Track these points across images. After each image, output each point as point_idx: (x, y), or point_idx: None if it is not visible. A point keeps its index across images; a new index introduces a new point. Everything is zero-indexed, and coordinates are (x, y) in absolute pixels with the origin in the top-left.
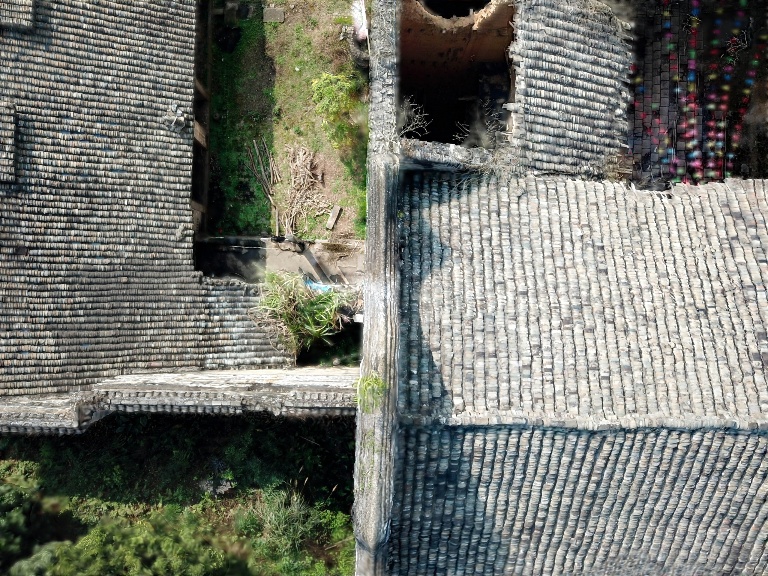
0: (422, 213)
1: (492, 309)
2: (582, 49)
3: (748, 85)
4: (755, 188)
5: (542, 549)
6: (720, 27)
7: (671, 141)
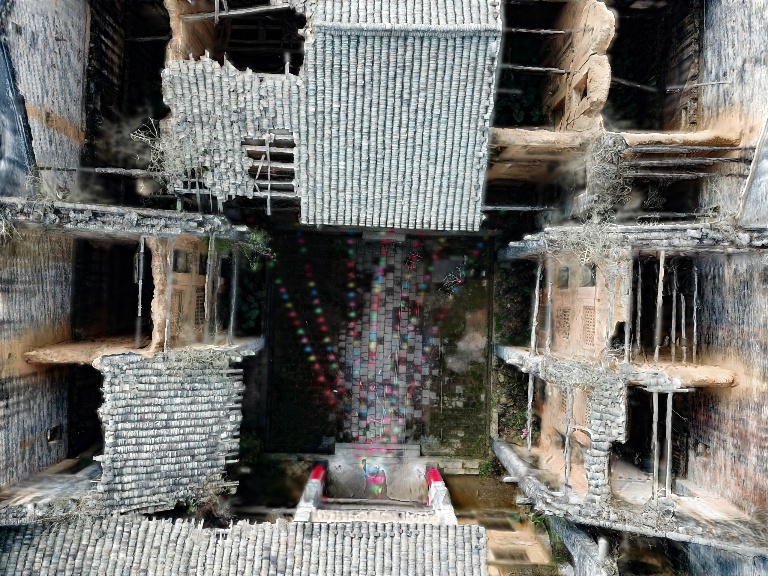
0: (10, 558)
1: None
2: (179, 394)
3: (463, 315)
4: (297, 531)
5: None
6: (437, 264)
7: (393, 365)
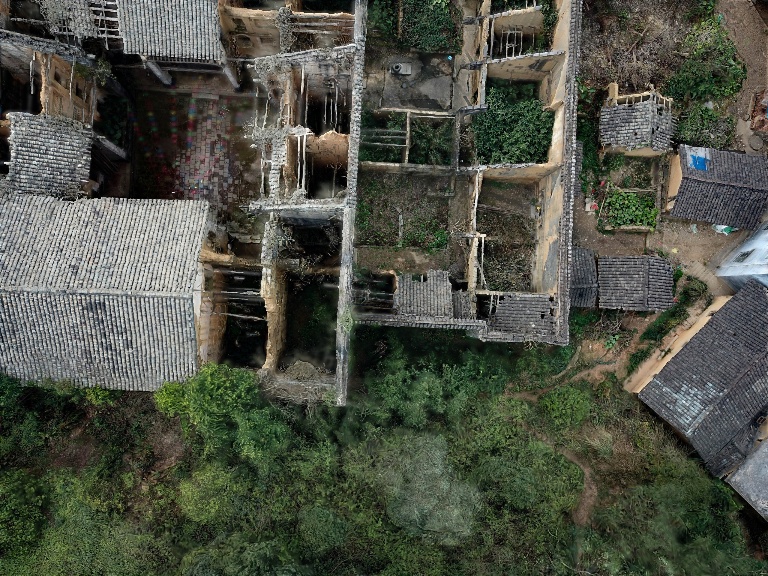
0: None
1: None
2: (54, 138)
3: None
4: (111, 201)
5: (3, 349)
6: (239, 115)
7: (210, 177)
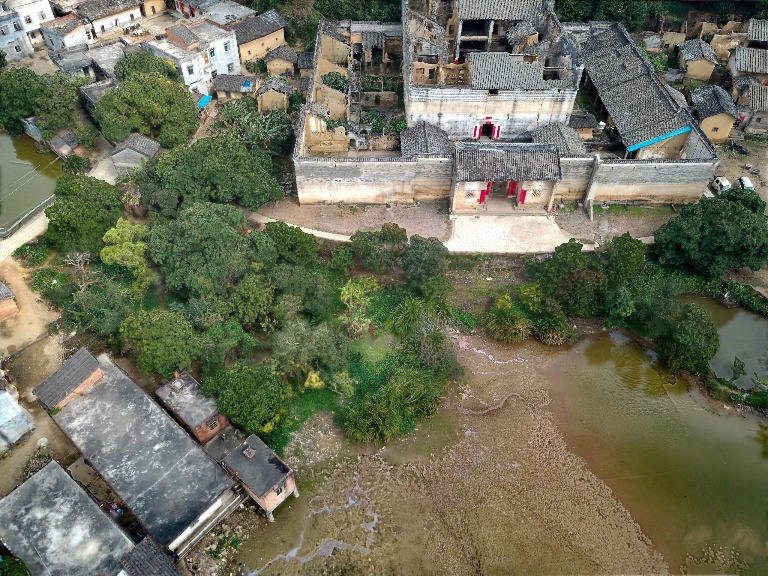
0: None
1: (532, 1)
2: None
3: None
4: None
5: None
6: None
7: None
